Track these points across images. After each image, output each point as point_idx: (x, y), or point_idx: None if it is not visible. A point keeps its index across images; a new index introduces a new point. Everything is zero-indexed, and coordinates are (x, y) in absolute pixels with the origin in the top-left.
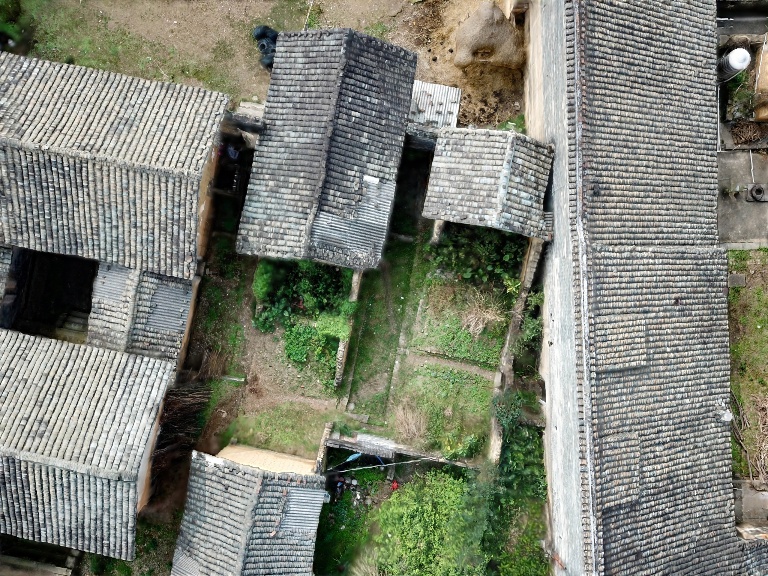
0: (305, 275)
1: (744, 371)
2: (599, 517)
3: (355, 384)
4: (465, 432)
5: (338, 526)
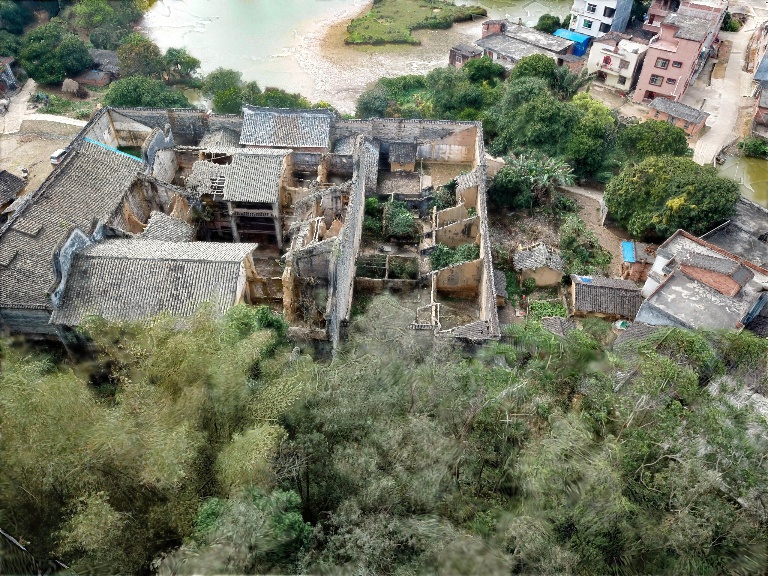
0: None
1: None
2: None
3: None
4: None
5: None
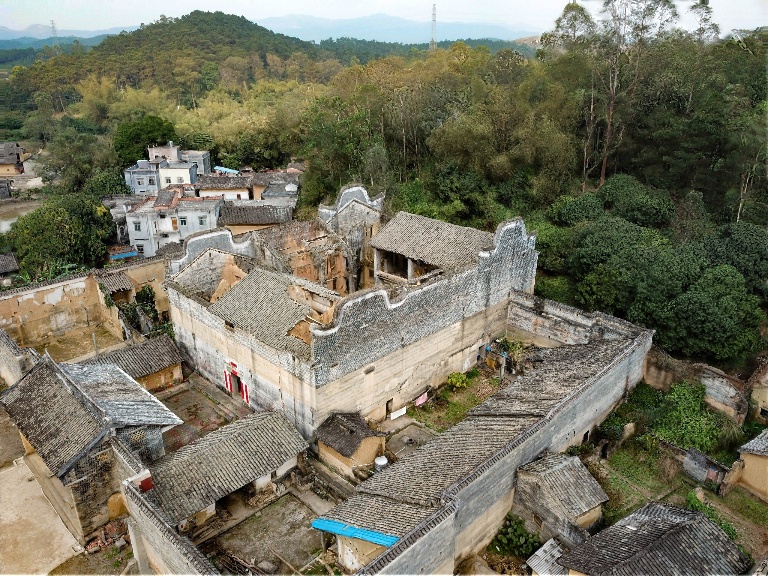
0: None
1: None
2: None
3: None
4: (639, 449)
5: None
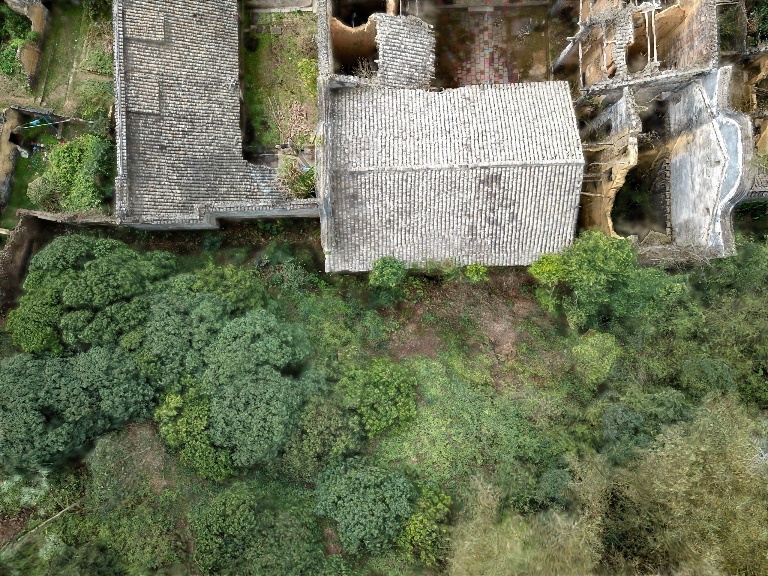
0: (11, 20)
1: (281, 85)
2: (123, 111)
3: (47, 91)
4: None
5: (33, 172)
